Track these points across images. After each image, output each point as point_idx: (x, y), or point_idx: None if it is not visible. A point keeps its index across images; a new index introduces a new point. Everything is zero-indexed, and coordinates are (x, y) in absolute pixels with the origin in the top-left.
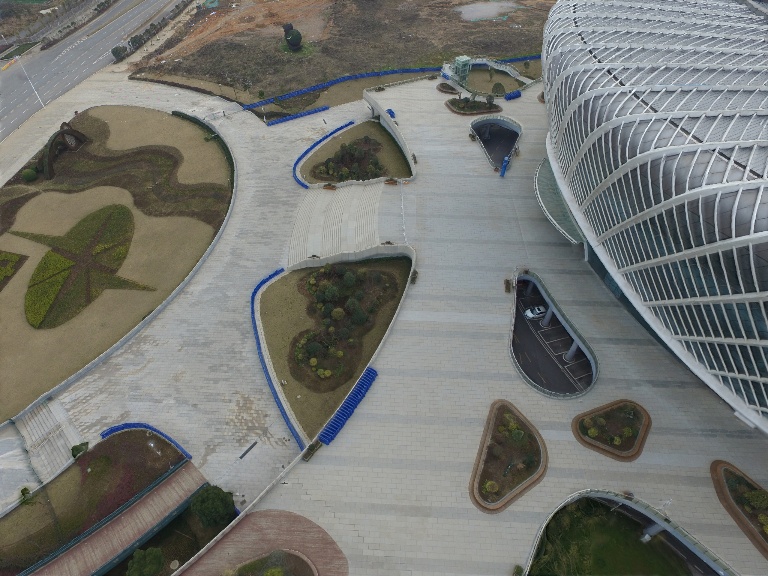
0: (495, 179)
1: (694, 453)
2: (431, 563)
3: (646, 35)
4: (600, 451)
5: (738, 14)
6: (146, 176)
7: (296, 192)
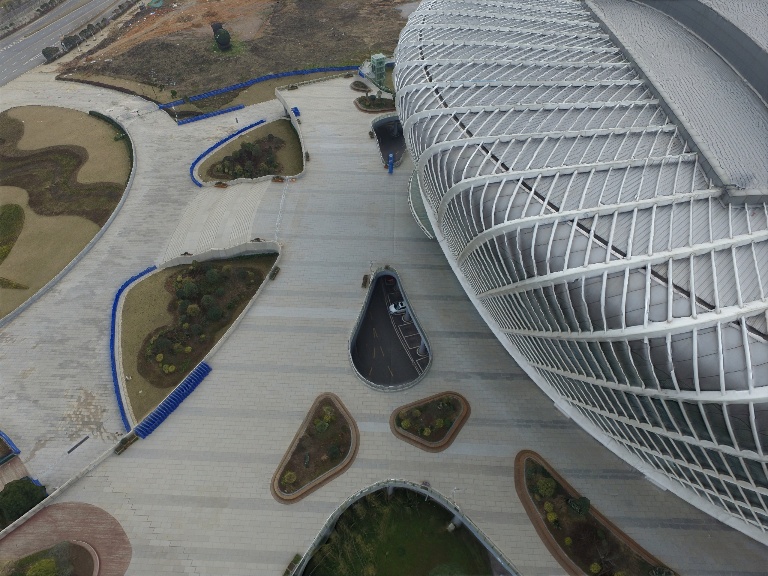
0: (383, 176)
1: (504, 443)
2: (214, 552)
3: (475, 32)
4: (411, 442)
5: (568, 10)
6: (47, 176)
7: (189, 190)
